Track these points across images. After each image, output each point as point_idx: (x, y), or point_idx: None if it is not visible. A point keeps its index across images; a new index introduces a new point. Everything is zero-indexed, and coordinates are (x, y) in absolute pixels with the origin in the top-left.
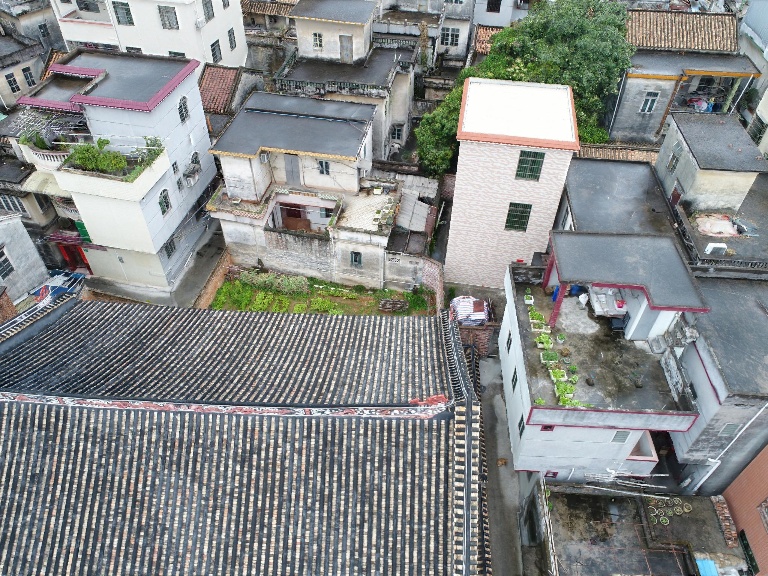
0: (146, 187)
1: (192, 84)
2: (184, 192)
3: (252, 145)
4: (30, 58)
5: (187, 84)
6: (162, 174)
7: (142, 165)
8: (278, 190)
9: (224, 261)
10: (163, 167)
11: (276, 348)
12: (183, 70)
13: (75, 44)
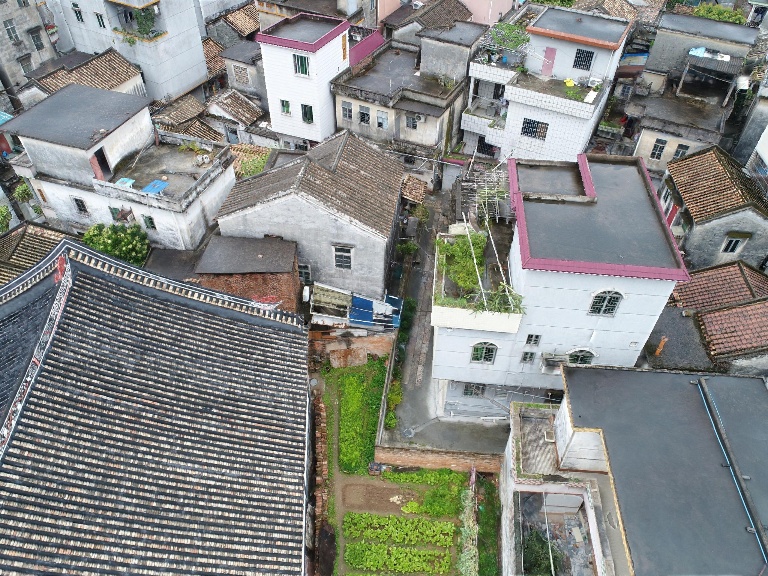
0: (454, 322)
1: (655, 291)
2: (530, 368)
3: (603, 416)
4: (697, 140)
5: (643, 285)
6: (494, 330)
7: (474, 303)
8: (589, 488)
9: (484, 460)
10: (501, 326)
11: (188, 568)
12: (643, 267)
13: (758, 158)
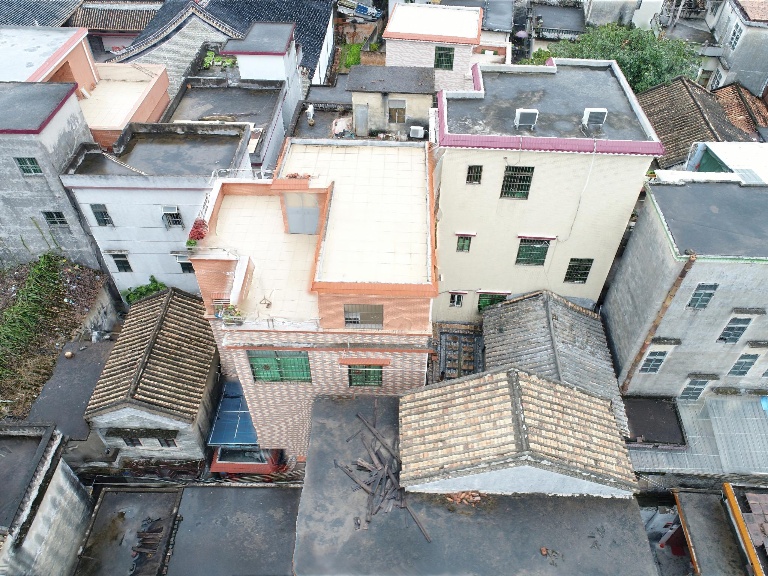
0: None
1: None
2: None
3: None
4: None
5: None
6: None
7: None
8: None
9: None
10: None
11: None
12: None
13: None
